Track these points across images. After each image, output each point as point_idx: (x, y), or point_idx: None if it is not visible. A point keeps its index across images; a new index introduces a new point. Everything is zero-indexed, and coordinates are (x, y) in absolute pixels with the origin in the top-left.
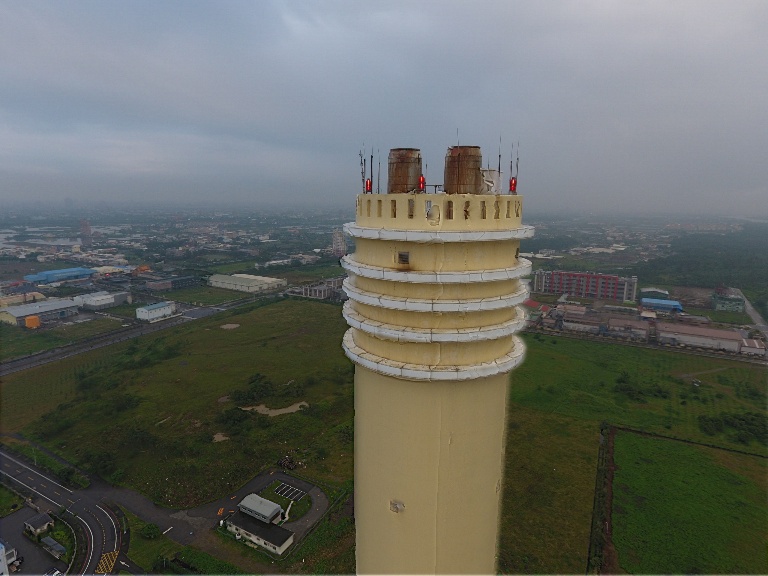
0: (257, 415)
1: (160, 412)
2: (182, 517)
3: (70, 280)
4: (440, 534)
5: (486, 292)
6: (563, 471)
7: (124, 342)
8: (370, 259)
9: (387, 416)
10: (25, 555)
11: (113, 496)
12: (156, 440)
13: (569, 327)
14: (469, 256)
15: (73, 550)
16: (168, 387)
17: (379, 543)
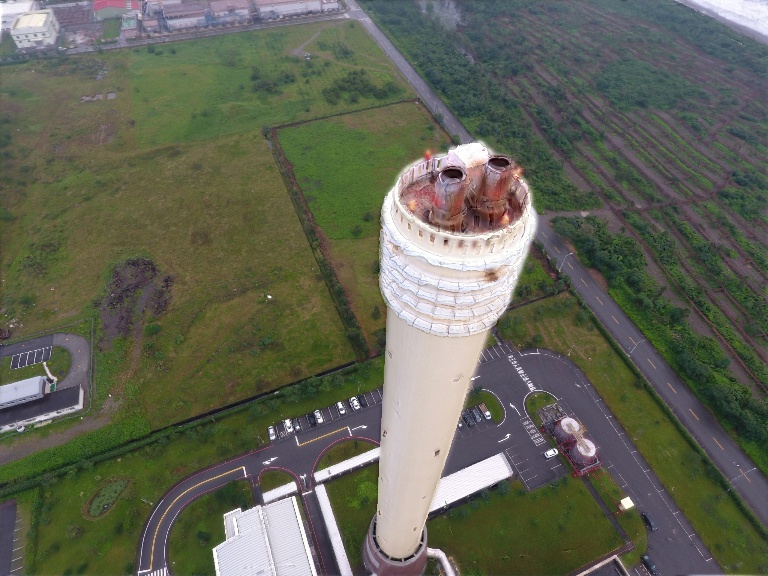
0: None
1: None
2: None
3: None
4: None
5: None
6: (259, 189)
7: None
8: (461, 279)
9: None
10: None
11: None
12: None
13: (176, 25)
14: None
15: None
16: None
17: None
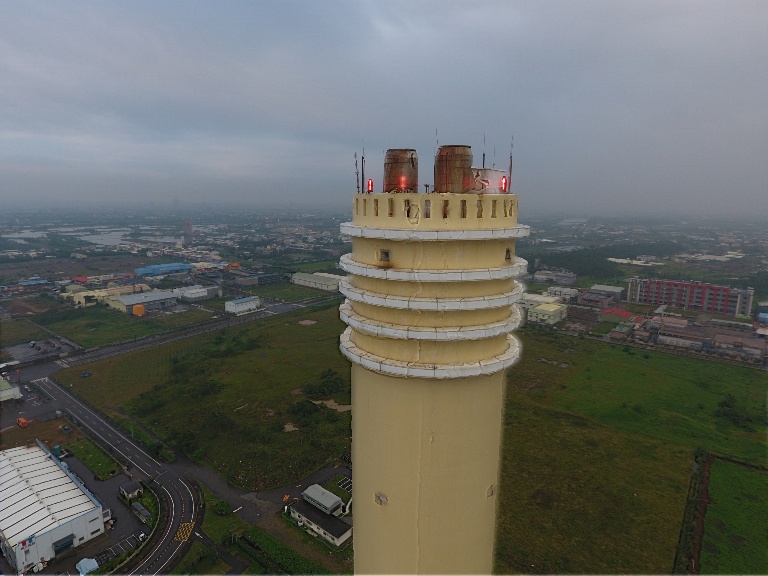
0: (326, 409)
1: (239, 399)
2: (251, 499)
3: (172, 274)
4: (422, 531)
5: (466, 292)
6: (645, 497)
7: (213, 332)
8: (358, 256)
9: (374, 410)
10: (118, 516)
11: (193, 472)
12: (233, 425)
13: (665, 341)
14: (449, 255)
15: (157, 517)
16: (248, 376)
17: (368, 534)
